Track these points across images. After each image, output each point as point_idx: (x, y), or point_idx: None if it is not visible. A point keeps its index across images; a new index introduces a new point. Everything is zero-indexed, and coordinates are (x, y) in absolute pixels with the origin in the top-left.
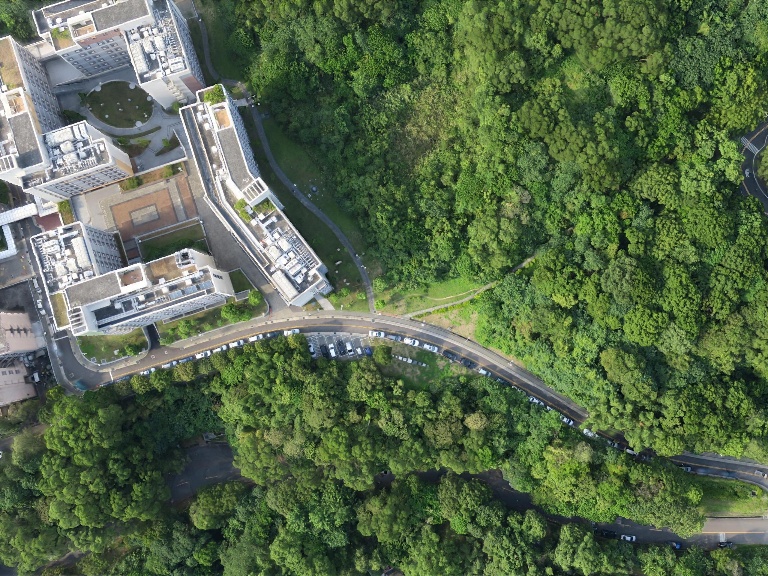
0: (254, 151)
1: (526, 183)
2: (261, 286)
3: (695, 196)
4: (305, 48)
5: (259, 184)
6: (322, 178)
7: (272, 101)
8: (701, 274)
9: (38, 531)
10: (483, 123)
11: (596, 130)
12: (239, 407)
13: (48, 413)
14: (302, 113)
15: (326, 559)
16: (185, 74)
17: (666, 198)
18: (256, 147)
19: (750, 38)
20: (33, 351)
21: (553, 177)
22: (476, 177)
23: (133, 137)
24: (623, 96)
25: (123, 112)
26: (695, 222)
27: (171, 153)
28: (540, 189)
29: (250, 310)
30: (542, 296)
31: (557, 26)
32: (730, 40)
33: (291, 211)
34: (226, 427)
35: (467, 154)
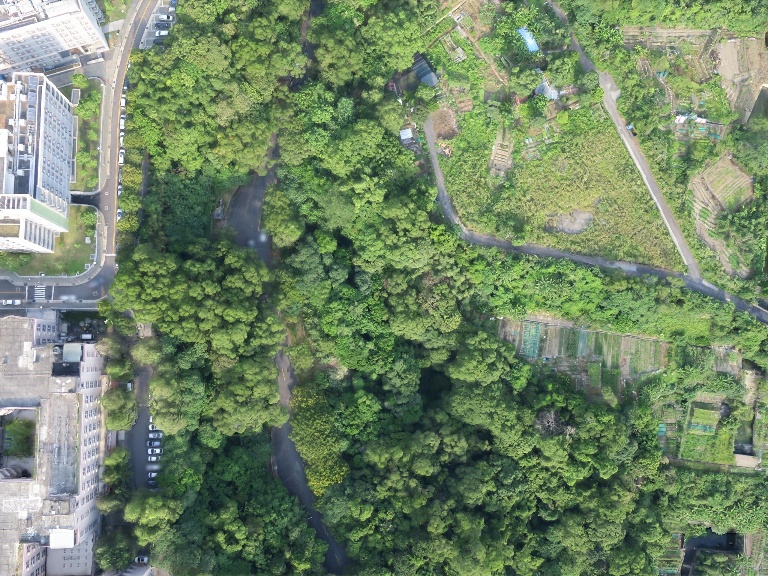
0: None
1: None
2: None
3: None
4: None
5: None
6: None
7: None
8: None
9: (241, 378)
10: None
11: None
12: (182, 131)
13: (122, 320)
14: None
15: (358, 119)
16: None
17: None
18: None
19: None
20: (55, 326)
21: None
22: None
23: None
24: None
25: None
26: None
27: None
28: None
29: None
30: None
31: None
32: None
33: None
34: (207, 173)
35: None
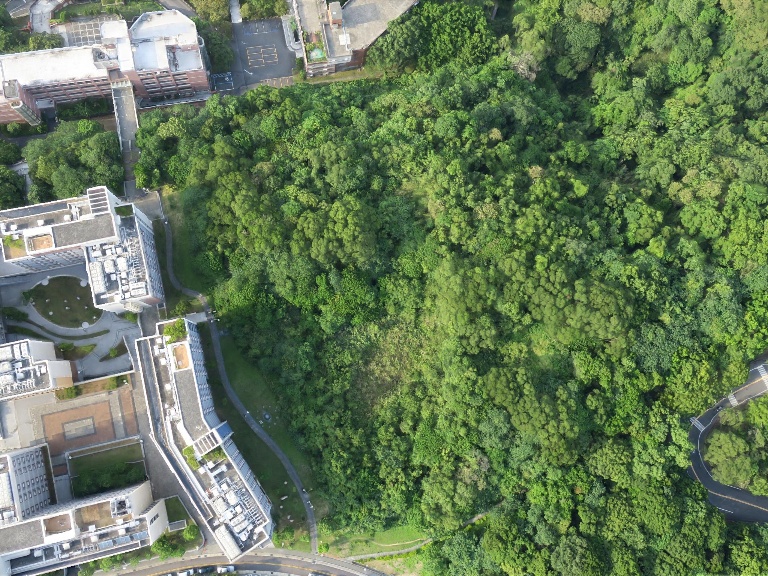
0: (208, 370)
1: (485, 447)
2: (198, 516)
3: (646, 479)
4: (276, 281)
5: (213, 436)
6: (277, 408)
7: (234, 325)
8: (647, 558)
9: None
10: (448, 380)
11: (559, 408)
12: None
13: None
14: (264, 339)
15: None
16: (146, 298)
17: (619, 477)
18: (211, 367)
19: (706, 330)
20: None
21: (512, 444)
22: (436, 434)
23: (77, 338)
24: (586, 374)
25: (70, 311)
26: (645, 507)
27: (117, 360)
28: (499, 455)
29: (183, 543)
30: (491, 562)
31: (529, 298)
32: (688, 331)
33: (240, 437)
34: None
35: (428, 403)
